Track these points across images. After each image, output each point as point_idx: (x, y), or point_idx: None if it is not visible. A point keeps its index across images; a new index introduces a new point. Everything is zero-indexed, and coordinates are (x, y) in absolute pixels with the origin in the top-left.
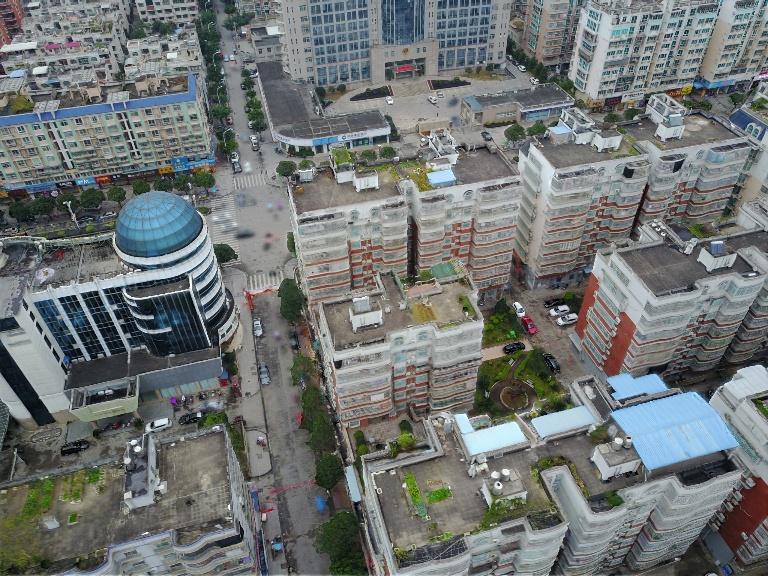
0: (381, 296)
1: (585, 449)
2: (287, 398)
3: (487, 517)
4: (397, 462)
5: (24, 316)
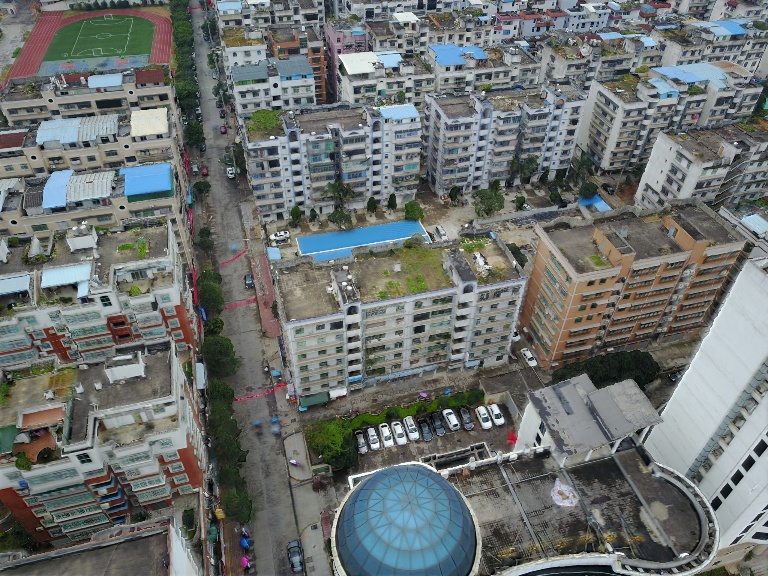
0: (98, 409)
1: (4, 268)
2: (267, 522)
3: (102, 228)
4: (147, 259)
5: (534, 417)
